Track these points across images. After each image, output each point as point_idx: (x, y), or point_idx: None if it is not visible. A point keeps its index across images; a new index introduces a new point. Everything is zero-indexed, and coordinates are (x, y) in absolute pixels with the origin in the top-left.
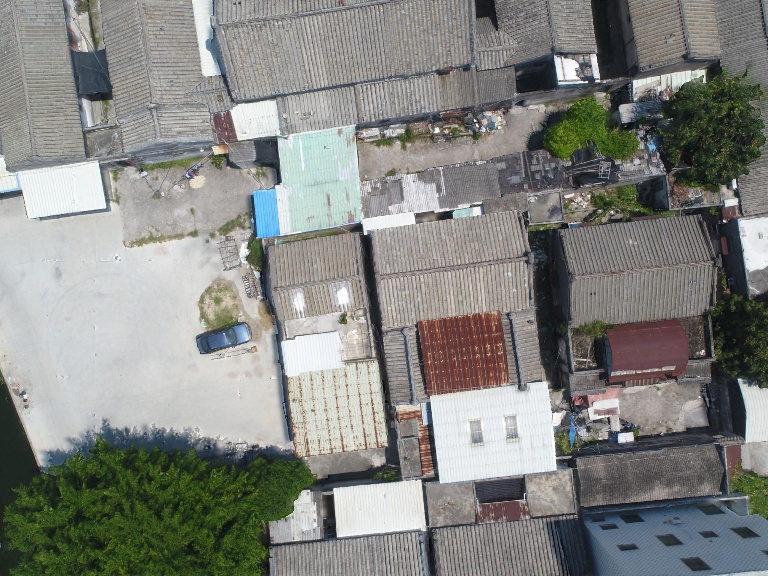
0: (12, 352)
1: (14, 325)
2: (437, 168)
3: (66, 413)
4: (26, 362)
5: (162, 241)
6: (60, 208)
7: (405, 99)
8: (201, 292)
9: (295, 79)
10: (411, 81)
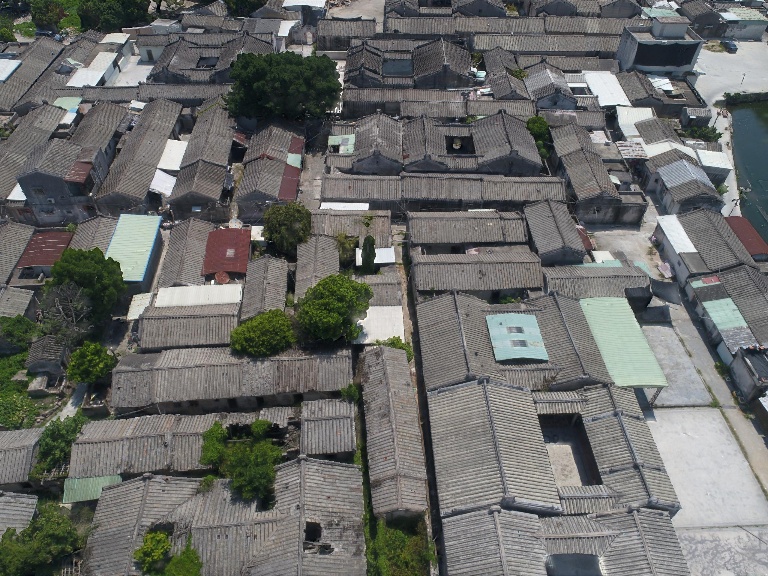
0: None
1: None
2: (649, 3)
3: None
4: (762, 86)
5: None
6: None
7: None
8: None
9: None
10: None
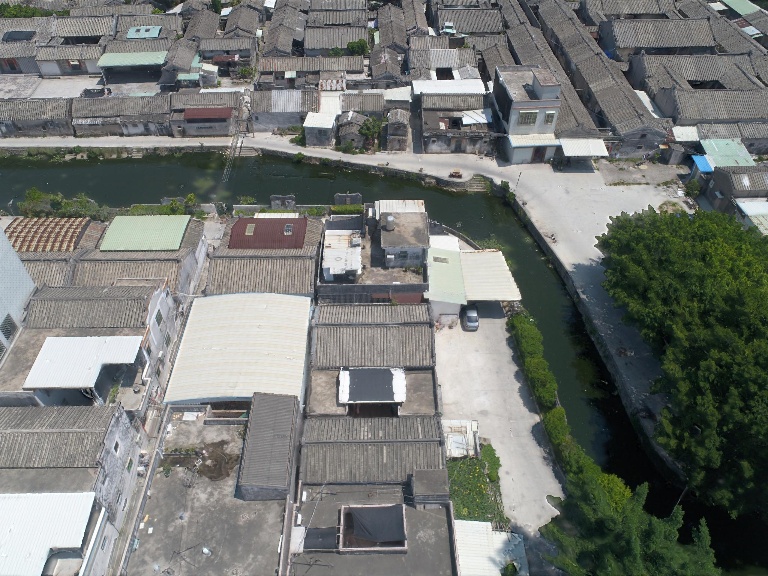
0: (542, 219)
1: (542, 209)
2: None
3: (582, 247)
4: (552, 224)
5: (628, 185)
6: (583, 153)
7: (765, 131)
8: (658, 205)
9: (711, 114)
10: (766, 125)
